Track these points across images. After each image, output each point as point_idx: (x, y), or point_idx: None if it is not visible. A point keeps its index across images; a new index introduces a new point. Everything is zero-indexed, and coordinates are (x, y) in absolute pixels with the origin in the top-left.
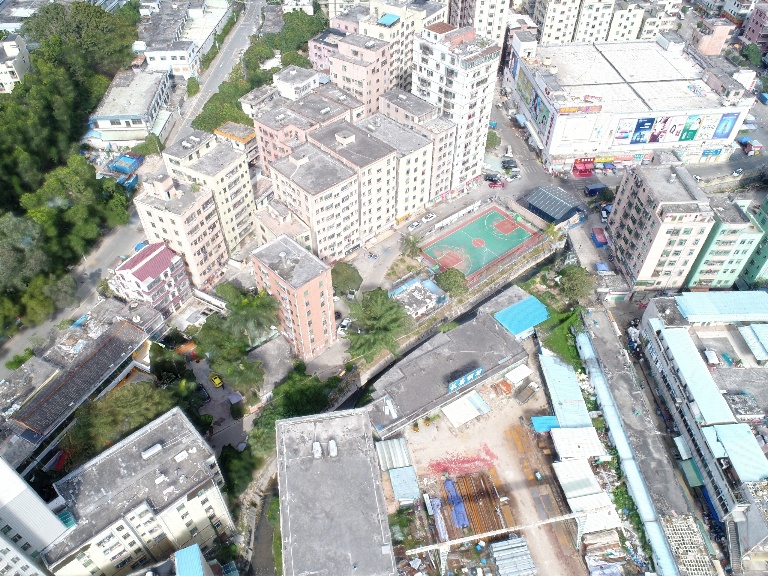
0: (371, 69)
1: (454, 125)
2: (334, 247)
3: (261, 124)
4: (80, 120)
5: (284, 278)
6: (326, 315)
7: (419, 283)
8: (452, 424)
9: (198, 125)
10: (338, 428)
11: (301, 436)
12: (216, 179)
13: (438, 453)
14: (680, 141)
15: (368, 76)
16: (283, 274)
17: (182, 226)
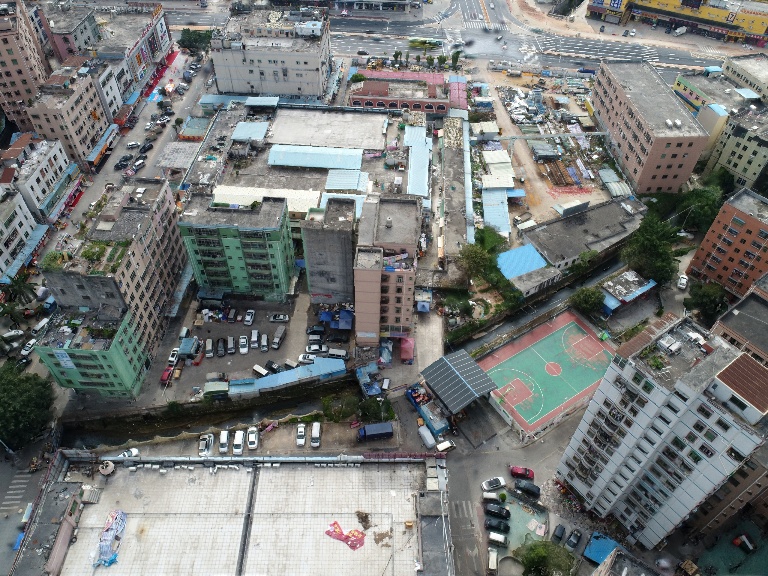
0: None
1: None
2: None
3: None
4: None
5: (761, 203)
6: None
7: None
8: None
9: None
10: (670, 134)
11: (690, 133)
12: None
13: (586, 197)
14: None
15: None
16: (765, 206)
17: None
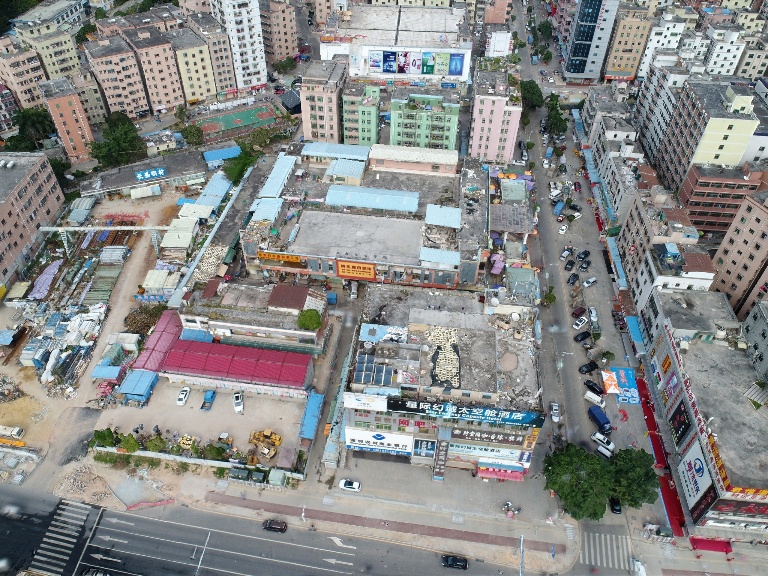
0: (201, 2)
1: (226, 36)
2: (124, 105)
3: (97, 24)
4: (4, 22)
5: (48, 96)
6: (83, 131)
7: (170, 132)
8: (131, 197)
9: (80, 32)
10: (23, 160)
11: None
12: (41, 45)
13: (115, 211)
14: (423, 74)
15: (199, 7)
16: (49, 95)
17: (8, 68)
